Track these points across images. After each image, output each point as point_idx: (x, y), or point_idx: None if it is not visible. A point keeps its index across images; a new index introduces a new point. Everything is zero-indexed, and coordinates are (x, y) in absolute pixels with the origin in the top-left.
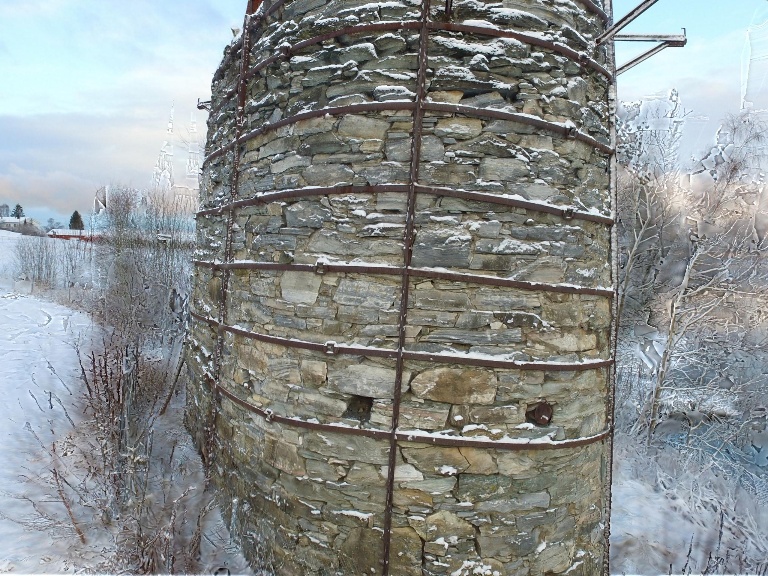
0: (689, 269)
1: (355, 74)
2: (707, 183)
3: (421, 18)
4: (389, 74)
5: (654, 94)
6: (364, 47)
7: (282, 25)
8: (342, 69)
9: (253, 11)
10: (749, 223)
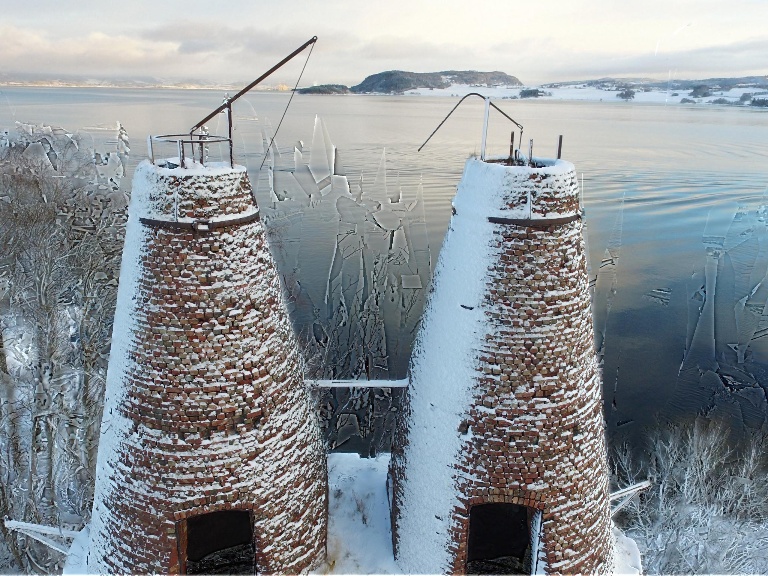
0: None
1: None
2: None
3: None
4: None
5: (95, 126)
6: None
7: None
8: None
9: None
10: (308, 331)
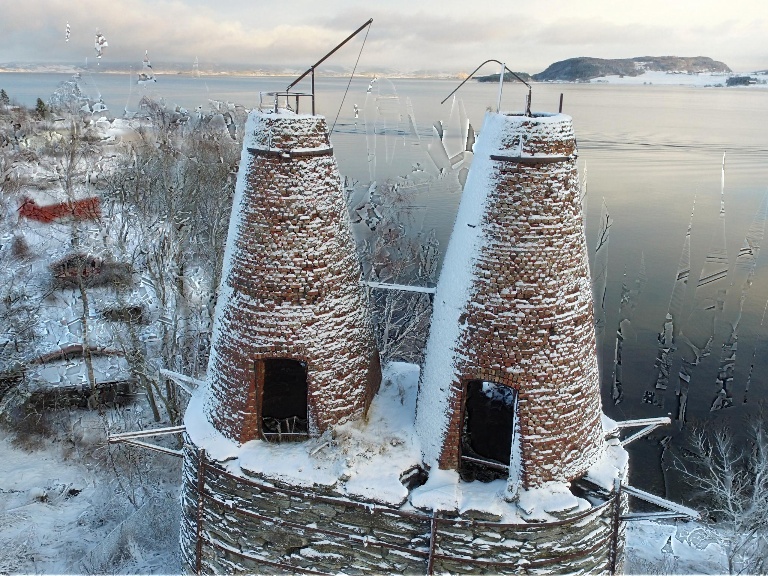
0: (388, 324)
1: (584, 575)
2: (365, 232)
3: (612, 530)
4: (599, 568)
5: (268, 103)
6: (590, 560)
7: (515, 545)
8: (577, 575)
9: (257, 380)
10: None
